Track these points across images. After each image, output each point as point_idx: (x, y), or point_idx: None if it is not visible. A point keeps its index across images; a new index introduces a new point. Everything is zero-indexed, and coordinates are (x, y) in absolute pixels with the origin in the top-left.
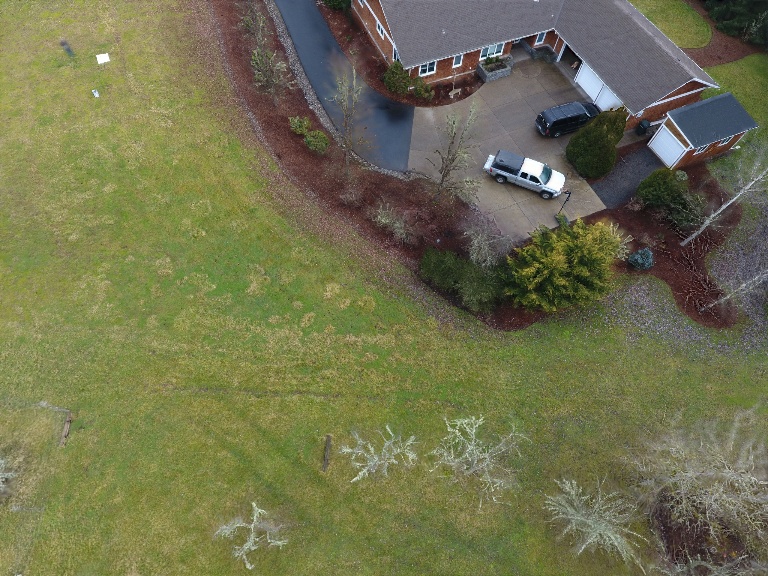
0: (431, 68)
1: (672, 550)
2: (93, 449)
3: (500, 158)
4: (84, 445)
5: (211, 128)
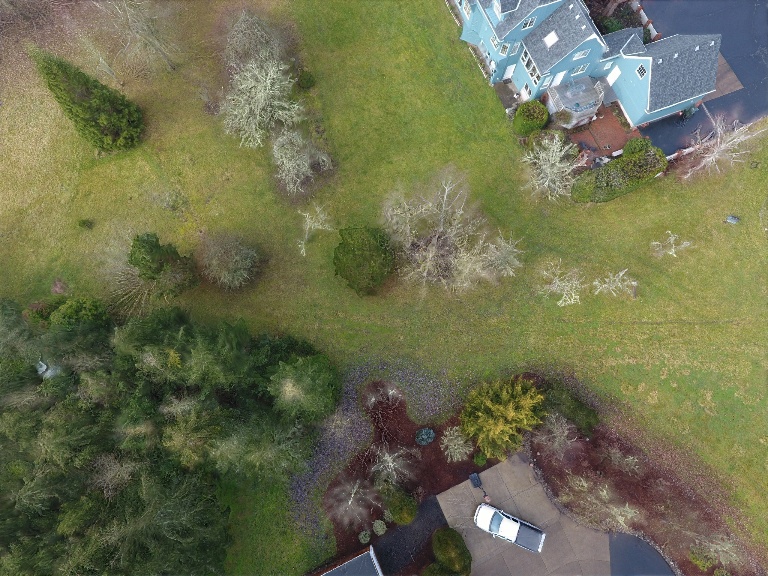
0: None
1: None
2: (762, 286)
3: None
4: (767, 288)
5: None
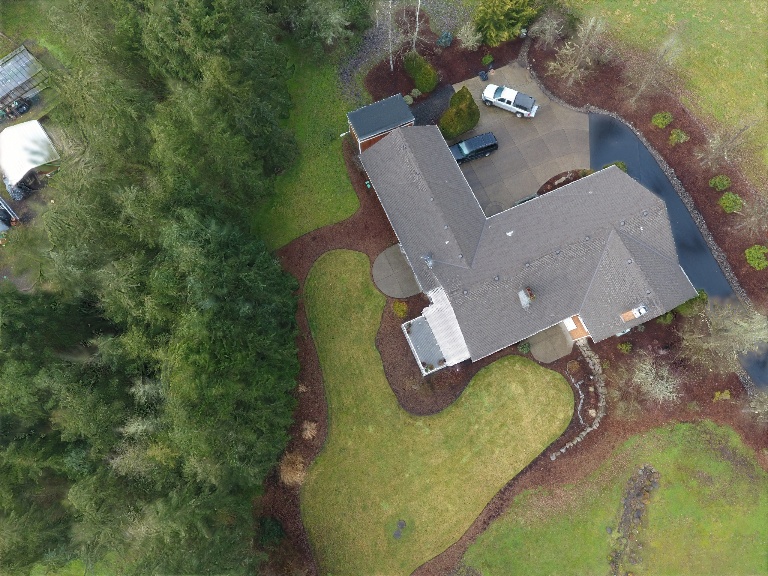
0: None
1: None
2: None
3: (526, 116)
4: None
5: None
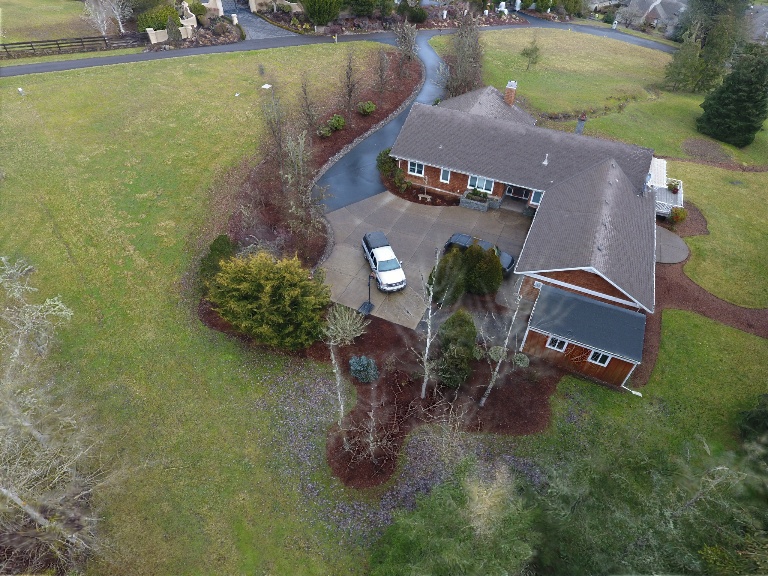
0: (420, 171)
1: (2, 540)
2: None
3: None
4: None
5: (257, 132)
